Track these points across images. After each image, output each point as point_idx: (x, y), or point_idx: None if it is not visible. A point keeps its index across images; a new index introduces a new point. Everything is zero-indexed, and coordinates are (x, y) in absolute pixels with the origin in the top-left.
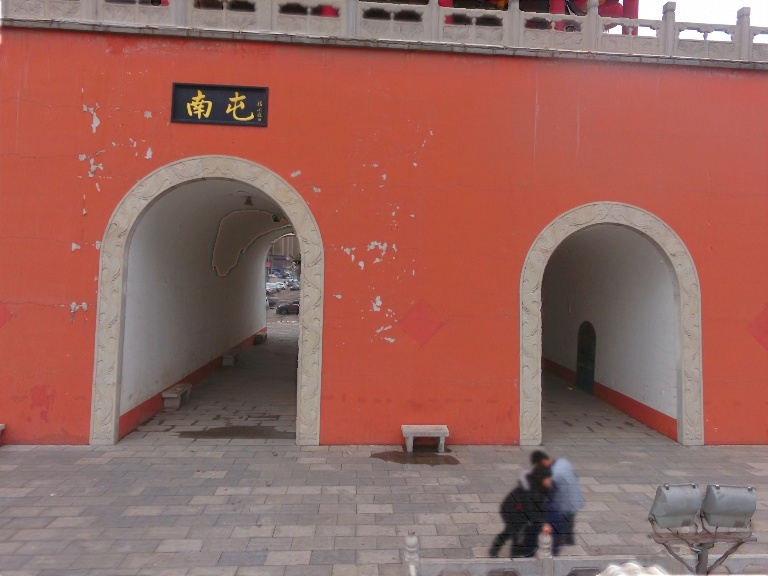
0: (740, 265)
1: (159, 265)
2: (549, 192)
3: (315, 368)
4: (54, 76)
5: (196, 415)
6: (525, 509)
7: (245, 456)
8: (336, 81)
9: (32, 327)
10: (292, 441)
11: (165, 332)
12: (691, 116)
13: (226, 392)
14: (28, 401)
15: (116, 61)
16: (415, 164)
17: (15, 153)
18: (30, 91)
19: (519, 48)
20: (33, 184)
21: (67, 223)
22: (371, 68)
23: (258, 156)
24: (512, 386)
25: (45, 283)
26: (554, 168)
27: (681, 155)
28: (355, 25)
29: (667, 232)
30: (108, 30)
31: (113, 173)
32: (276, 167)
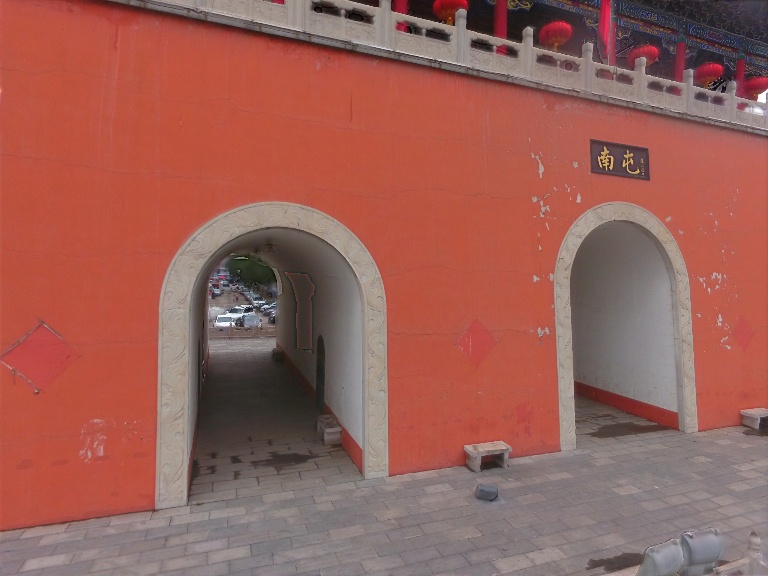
0: None
1: None
2: None
3: (691, 372)
4: (509, 125)
5: None
6: None
7: None
8: (684, 147)
9: (511, 351)
10: (675, 431)
11: None
12: None
13: None
14: (515, 418)
15: (550, 116)
16: (731, 214)
17: (486, 193)
18: (492, 137)
19: None
20: (501, 222)
21: (528, 258)
22: (703, 139)
23: (644, 203)
24: None
25: (517, 311)
26: None
27: None
28: (691, 104)
29: None
30: (548, 89)
31: (557, 214)
32: (656, 213)
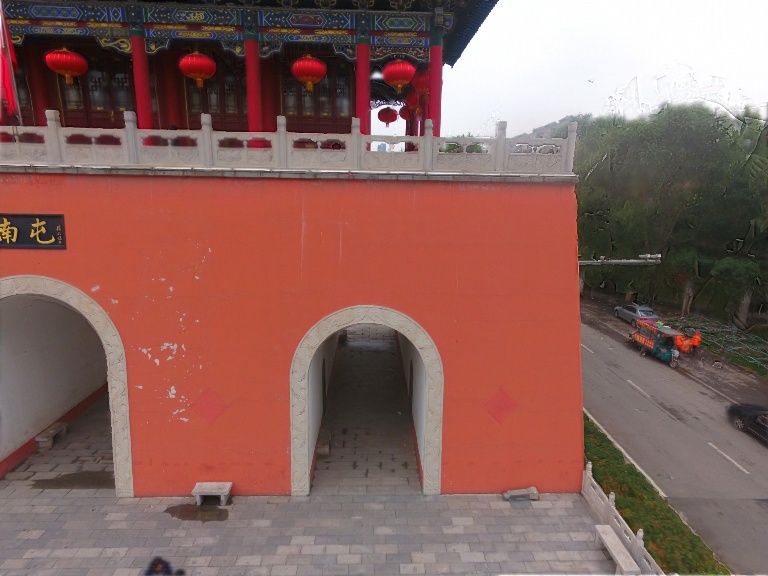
0: (482, 354)
1: (13, 343)
2: (315, 298)
3: (126, 442)
4: None
5: (61, 457)
6: (233, 574)
7: (69, 512)
8: (123, 206)
9: None
10: None
11: (32, 390)
12: (444, 227)
13: (102, 423)
14: None
15: None
16: (197, 277)
17: None
18: None
19: (284, 171)
20: None
21: None
22: (153, 193)
23: (62, 274)
24: (285, 453)
25: None
26: (319, 277)
27: (433, 262)
28: (136, 152)
29: (417, 330)
30: None
31: None
32: (78, 283)
